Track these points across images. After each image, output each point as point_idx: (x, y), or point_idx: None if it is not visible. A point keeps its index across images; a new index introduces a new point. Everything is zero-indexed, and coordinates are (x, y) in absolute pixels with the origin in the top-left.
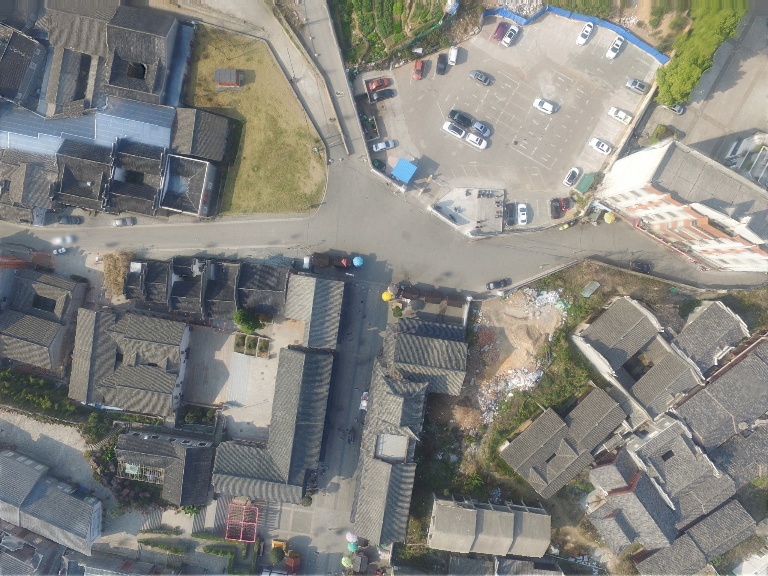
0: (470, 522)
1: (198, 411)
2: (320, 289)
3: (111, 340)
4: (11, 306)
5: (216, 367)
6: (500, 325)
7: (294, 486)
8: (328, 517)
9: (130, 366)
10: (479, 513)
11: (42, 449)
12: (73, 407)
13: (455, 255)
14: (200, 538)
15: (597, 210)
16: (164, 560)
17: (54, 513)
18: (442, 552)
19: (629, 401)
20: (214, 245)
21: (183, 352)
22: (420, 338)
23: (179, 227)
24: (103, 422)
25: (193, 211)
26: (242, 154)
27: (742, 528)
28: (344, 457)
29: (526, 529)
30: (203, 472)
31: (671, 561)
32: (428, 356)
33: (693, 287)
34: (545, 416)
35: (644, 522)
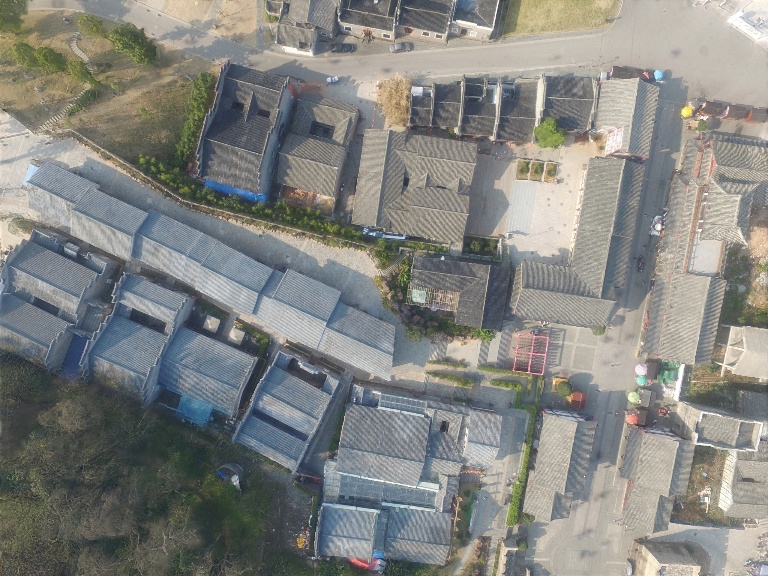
0: None
1: (481, 240)
2: (639, 91)
3: (400, 161)
4: (283, 136)
5: (495, 197)
6: None
7: (606, 302)
8: (611, 352)
9: (420, 188)
10: None
11: (329, 275)
12: (359, 232)
13: (753, 70)
14: (487, 371)
15: None
16: (451, 393)
17: (359, 331)
18: (729, 388)
19: None
20: (496, 69)
21: None
22: (736, 145)
23: (459, 51)
24: (389, 248)
25: (486, 26)
26: None
27: None
28: (630, 288)
29: None
30: (501, 295)
31: None
32: (749, 161)
33: None
34: None
35: None
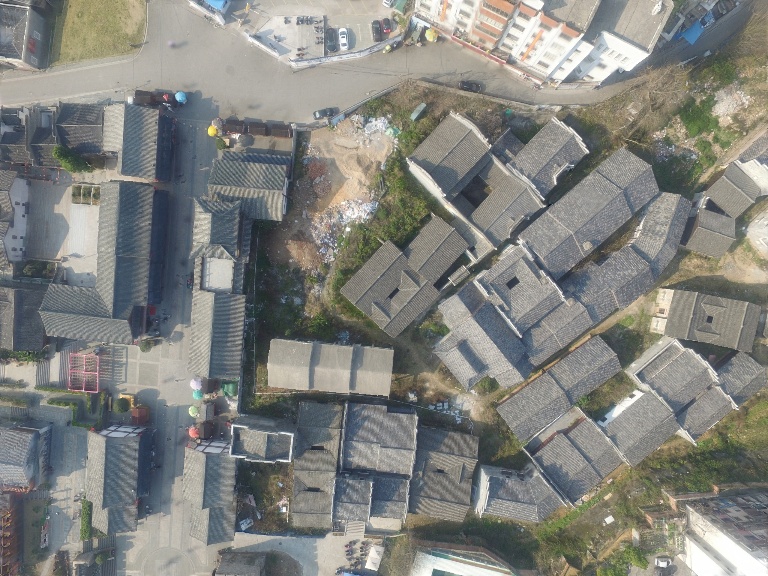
0: (305, 354)
1: (38, 264)
2: (132, 115)
3: None
4: None
5: (56, 221)
6: (330, 156)
7: (120, 321)
8: (174, 368)
9: None
10: (316, 347)
11: None
12: None
13: (280, 87)
14: (43, 390)
15: (418, 28)
16: (8, 413)
17: None
18: (292, 399)
19: (471, 230)
20: (47, 97)
21: (18, 203)
22: (238, 163)
23: (13, 82)
24: None
25: (17, 58)
26: (68, 3)
27: (602, 362)
28: (185, 304)
29: (367, 363)
30: (36, 317)
31: (531, 400)
32: (245, 178)
33: (525, 104)
34: (383, 248)
35: (488, 350)
